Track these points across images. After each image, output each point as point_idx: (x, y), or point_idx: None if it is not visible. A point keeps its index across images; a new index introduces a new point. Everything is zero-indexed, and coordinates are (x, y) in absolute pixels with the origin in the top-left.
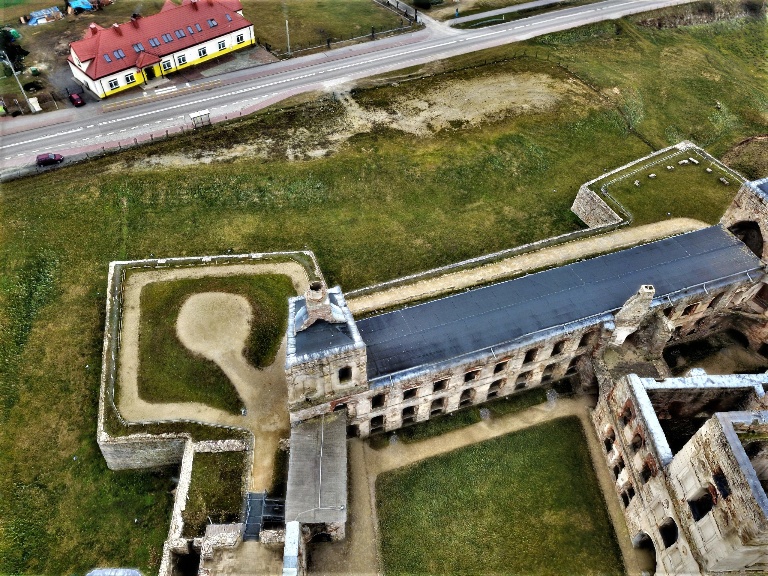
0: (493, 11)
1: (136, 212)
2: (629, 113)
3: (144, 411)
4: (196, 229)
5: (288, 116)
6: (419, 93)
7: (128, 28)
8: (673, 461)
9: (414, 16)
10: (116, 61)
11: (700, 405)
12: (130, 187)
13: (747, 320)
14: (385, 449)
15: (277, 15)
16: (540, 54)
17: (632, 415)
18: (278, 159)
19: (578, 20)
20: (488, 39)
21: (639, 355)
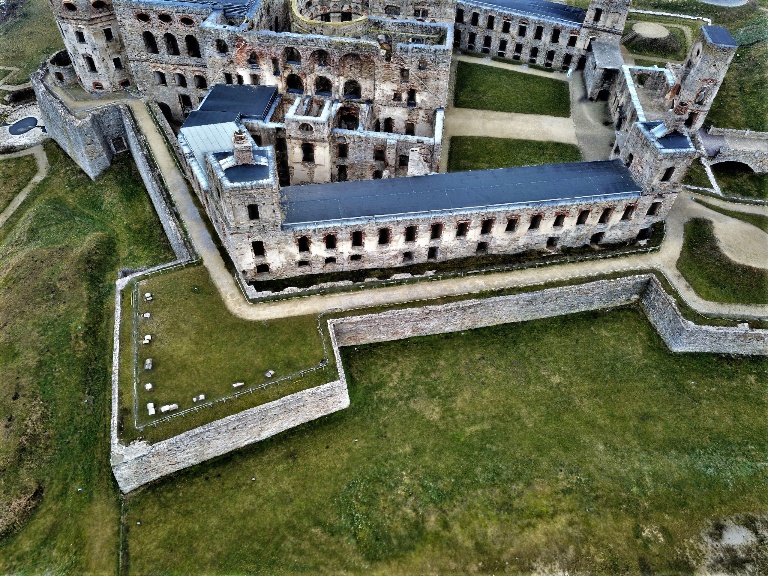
0: None
1: None
2: None
3: (764, 211)
4: None
5: None
6: None
7: None
8: None
9: None
10: None
11: None
12: None
13: None
14: None
15: None
16: None
17: None
18: None
19: None
20: None
21: None
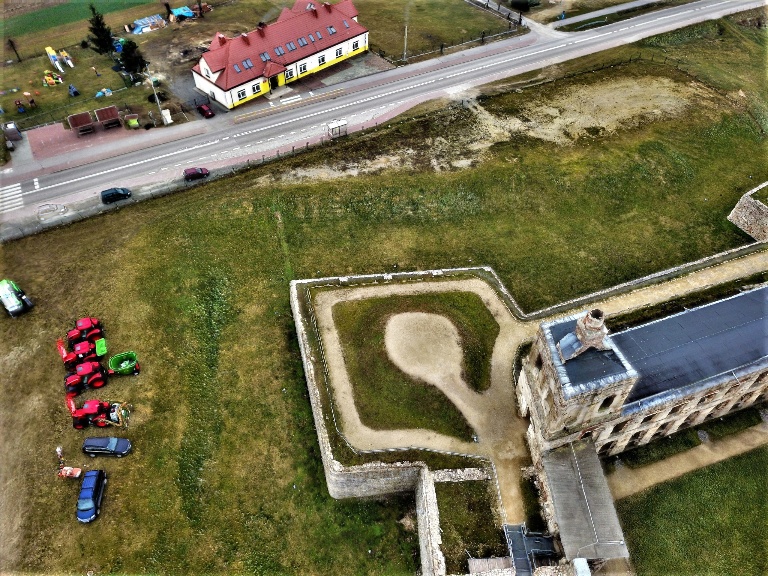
0: (593, 13)
1: (292, 227)
2: (760, 117)
3: (372, 438)
4: (356, 244)
5: (422, 125)
6: (546, 99)
7: (255, 37)
8: None
9: (518, 19)
10: (245, 71)
11: None
12: (282, 201)
13: None
14: (613, 475)
15: (380, 20)
16: (654, 57)
17: None
18: (425, 170)
19: (680, 21)
20: (596, 42)
21: None
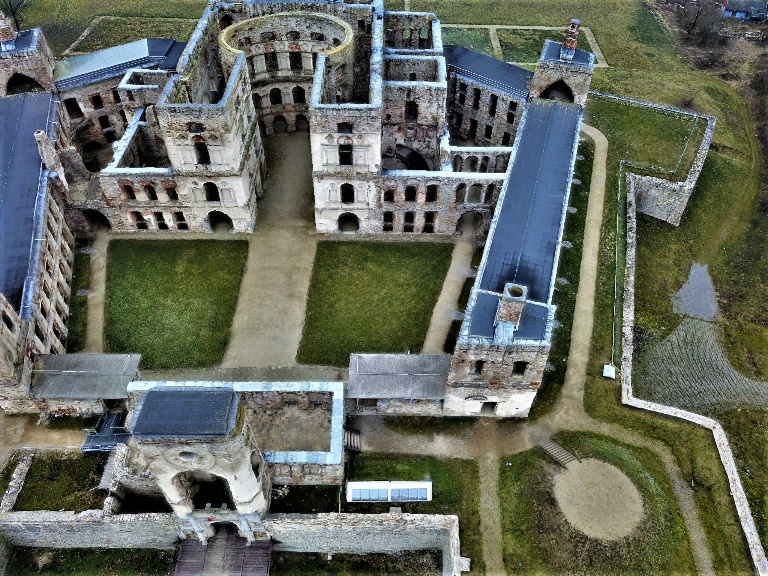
0: None
1: None
2: None
3: None
4: None
5: None
6: None
7: None
8: (172, 162)
9: None
10: None
11: (138, 158)
12: None
13: (84, 132)
14: None
15: None
16: None
17: (130, 185)
18: None
19: None
20: None
21: (82, 183)
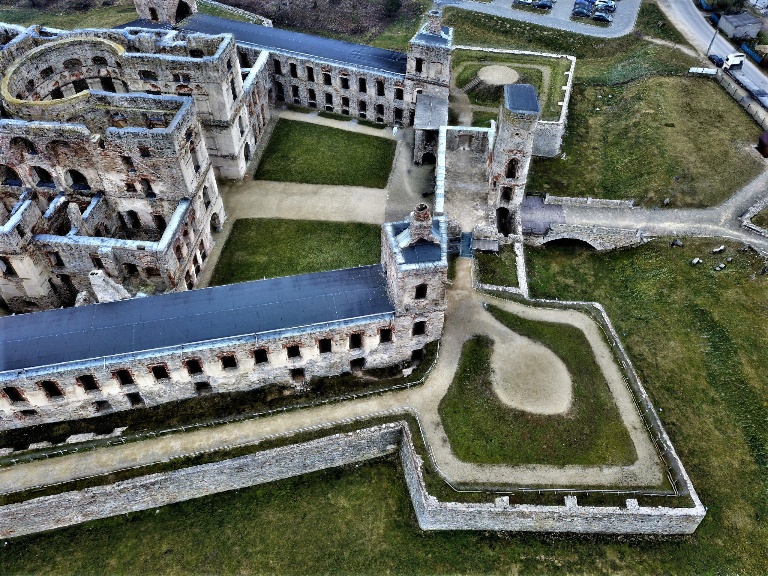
0: None
1: None
2: None
3: (572, 318)
4: None
5: None
6: None
7: None
8: None
9: None
10: None
11: None
12: None
13: None
14: None
15: None
16: None
17: None
18: None
19: None
20: None
21: None
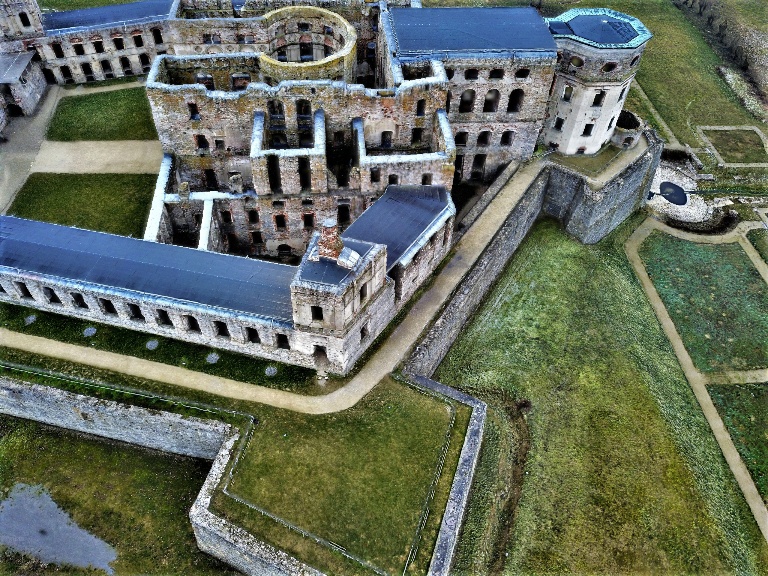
0: None
1: None
2: None
3: None
4: None
5: None
6: None
7: None
8: None
9: None
10: None
11: None
12: None
13: None
14: (72, 89)
15: None
16: None
17: None
18: None
19: None
20: None
21: None
